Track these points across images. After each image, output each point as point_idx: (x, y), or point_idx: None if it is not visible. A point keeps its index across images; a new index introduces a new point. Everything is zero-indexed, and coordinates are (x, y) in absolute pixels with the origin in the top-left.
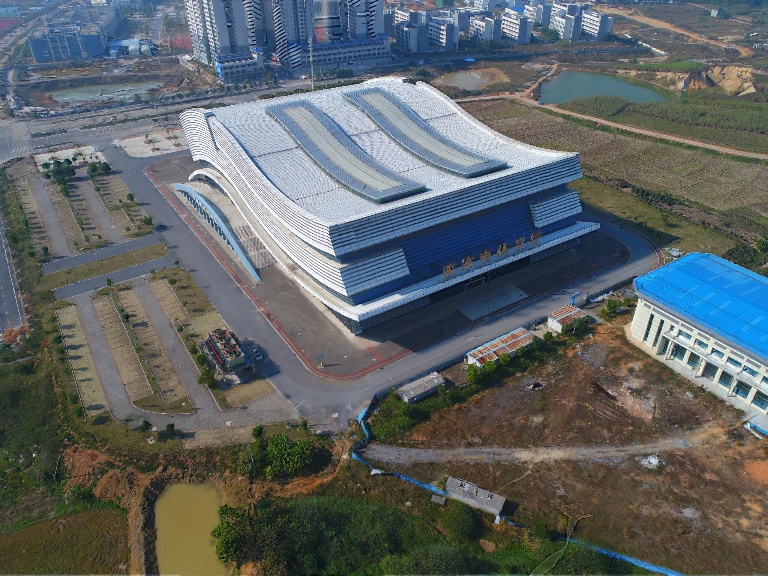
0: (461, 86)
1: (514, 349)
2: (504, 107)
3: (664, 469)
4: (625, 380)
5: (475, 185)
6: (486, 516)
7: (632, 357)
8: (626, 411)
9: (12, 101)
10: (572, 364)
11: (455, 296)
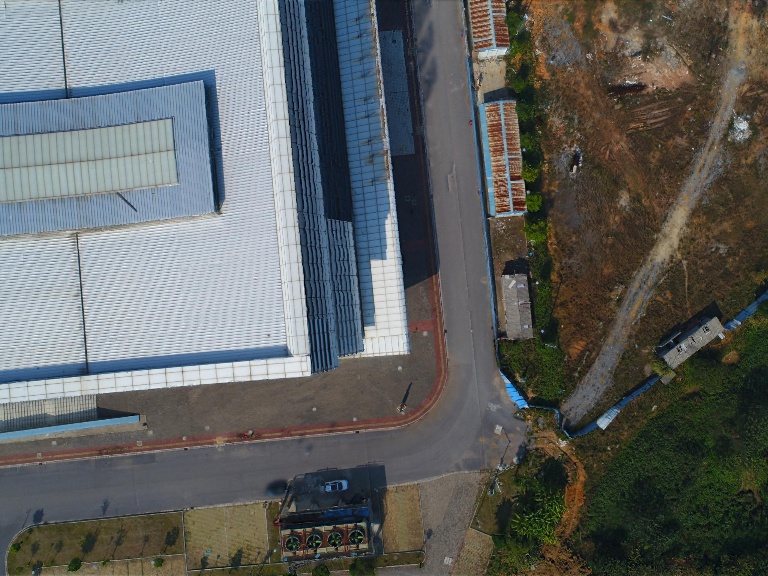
0: None
1: (519, 149)
2: None
3: (755, 124)
4: (624, 48)
5: None
6: (712, 343)
7: (596, 4)
8: (666, 91)
9: None
10: (564, 87)
11: None
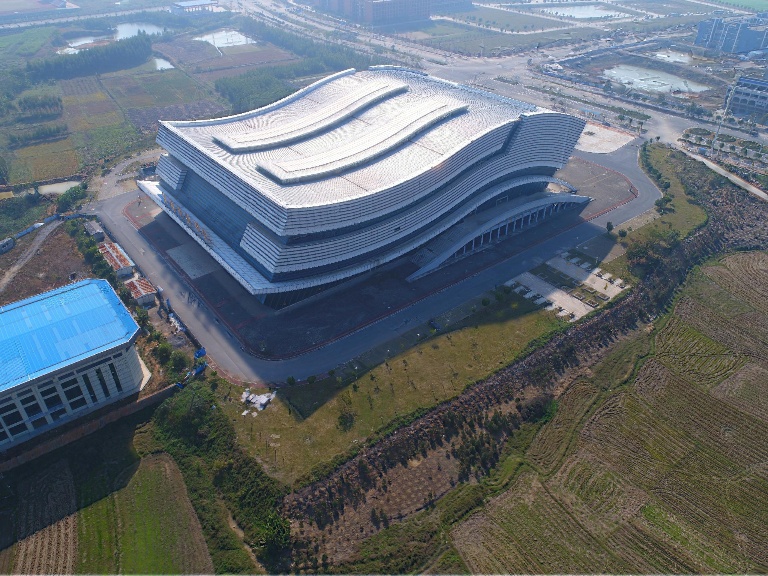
0: None
1: (107, 260)
2: None
3: None
4: None
5: None
6: None
7: None
8: None
9: (535, 53)
10: None
11: None
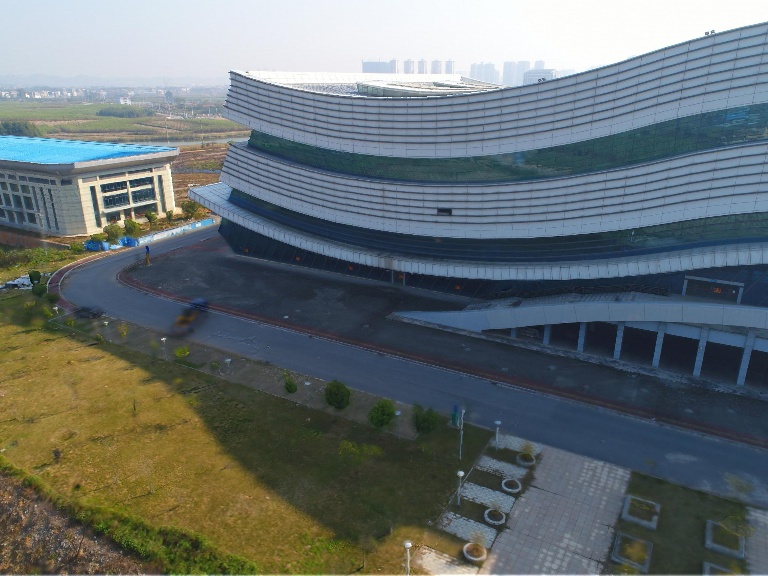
0: None
1: None
2: None
3: None
4: None
5: None
6: None
7: None
8: None
9: None
10: None
11: None
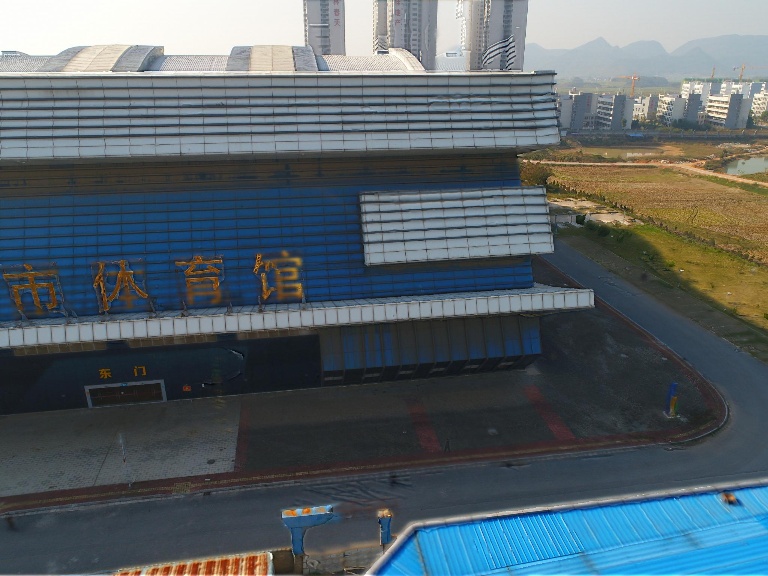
0: (600, 154)
1: None
2: (646, 174)
3: None
4: None
5: (109, 78)
6: None
7: None
8: None
9: None
10: None
11: (44, 413)
